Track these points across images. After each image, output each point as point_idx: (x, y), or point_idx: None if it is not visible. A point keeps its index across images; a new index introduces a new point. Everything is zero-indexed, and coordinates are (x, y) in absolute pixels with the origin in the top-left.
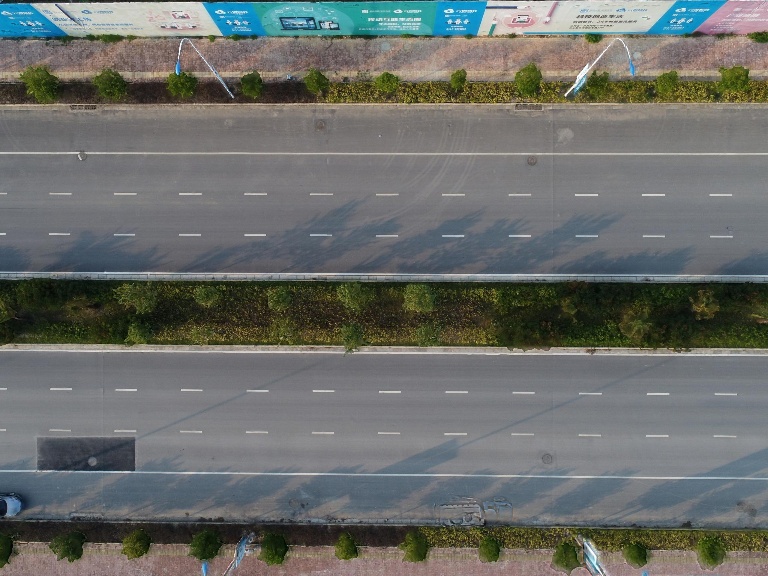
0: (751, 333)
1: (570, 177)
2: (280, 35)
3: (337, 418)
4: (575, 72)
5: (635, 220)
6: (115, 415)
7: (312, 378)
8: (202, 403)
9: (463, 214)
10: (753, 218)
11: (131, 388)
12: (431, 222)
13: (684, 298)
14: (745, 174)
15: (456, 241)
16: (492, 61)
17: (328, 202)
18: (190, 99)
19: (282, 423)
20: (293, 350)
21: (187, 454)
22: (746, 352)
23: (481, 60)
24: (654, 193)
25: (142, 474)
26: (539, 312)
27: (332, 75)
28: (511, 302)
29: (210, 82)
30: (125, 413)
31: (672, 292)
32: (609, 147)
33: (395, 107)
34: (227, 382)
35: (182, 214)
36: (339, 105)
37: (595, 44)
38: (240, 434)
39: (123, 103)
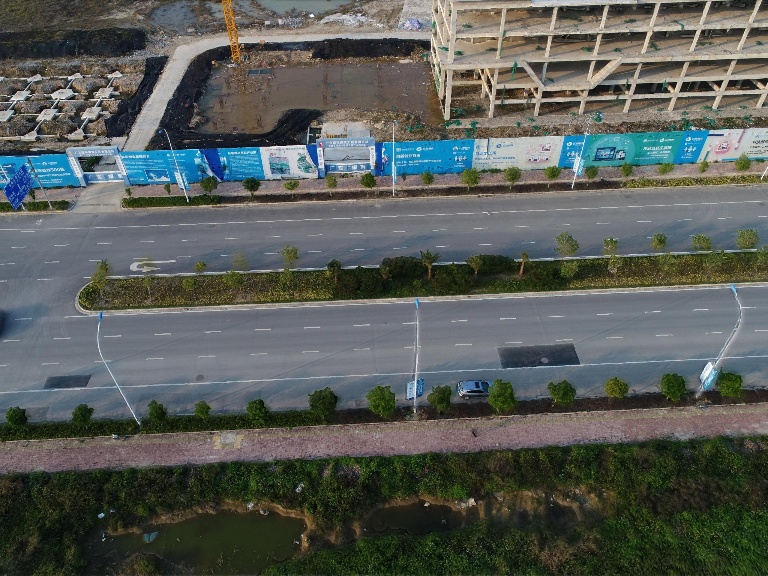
0: None
1: None
2: None
3: (719, 324)
4: (759, 172)
5: None
6: (553, 331)
7: (688, 303)
8: (616, 320)
9: (737, 225)
10: None
11: (560, 315)
12: (719, 229)
13: None
14: None
15: None
16: (711, 171)
17: (650, 224)
18: (547, 190)
19: (680, 329)
20: (666, 289)
21: (617, 352)
22: None
23: None
24: None
25: (587, 366)
26: None
27: (625, 179)
28: None
29: (557, 183)
30: (560, 329)
31: None
32: None
33: (667, 189)
34: (628, 308)
35: None
36: (634, 189)
37: (762, 163)
38: (652, 337)
39: (508, 193)
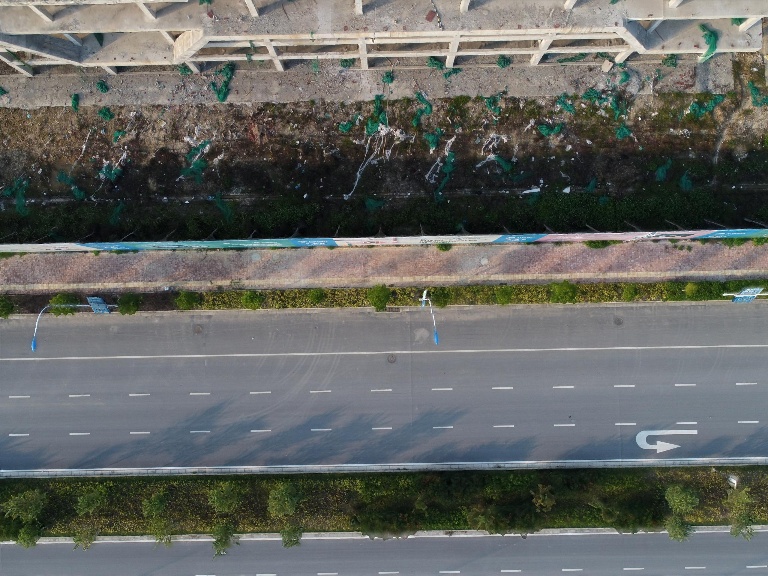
0: (592, 515)
1: (427, 373)
2: (159, 249)
3: None
4: (429, 277)
5: (486, 412)
6: None
7: (195, 564)
8: None
9: (330, 409)
10: (593, 408)
11: None
12: (301, 417)
13: (531, 484)
14: (585, 367)
15: (324, 434)
16: (353, 269)
17: (206, 401)
18: (77, 308)
19: None
20: (177, 538)
21: None
22: (589, 531)
23: (343, 268)
24: (503, 386)
25: None
26: (400, 499)
27: (207, 284)
28: (373, 493)
29: (95, 293)
30: None
31: (520, 479)
32: (461, 345)
33: (266, 312)
34: (116, 569)
35: (72, 415)
36: (215, 311)
37: (446, 252)
38: None
39: (16, 313)
